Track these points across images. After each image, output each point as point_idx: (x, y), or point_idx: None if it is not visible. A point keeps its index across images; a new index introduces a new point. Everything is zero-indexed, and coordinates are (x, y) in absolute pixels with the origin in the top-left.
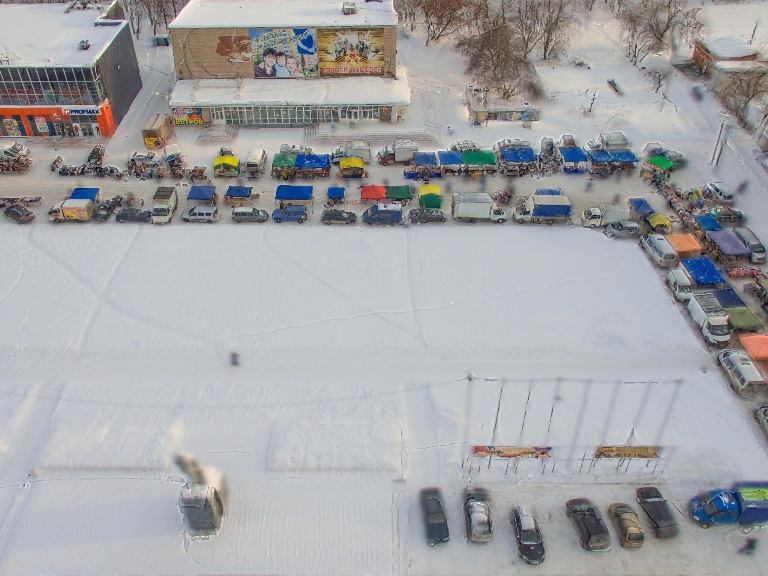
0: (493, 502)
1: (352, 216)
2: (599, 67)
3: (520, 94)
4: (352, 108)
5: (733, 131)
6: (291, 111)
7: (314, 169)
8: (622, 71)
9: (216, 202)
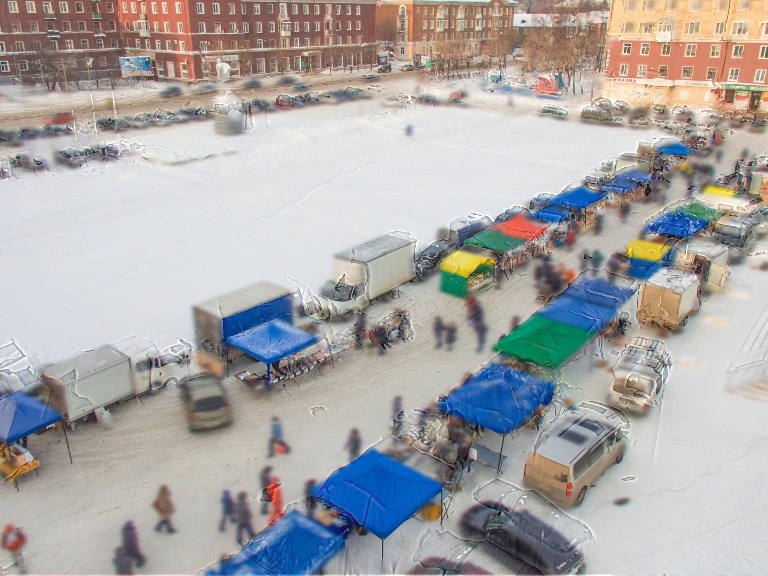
0: None
1: None
2: None
3: None
4: None
5: None
6: None
7: None
8: None
9: None
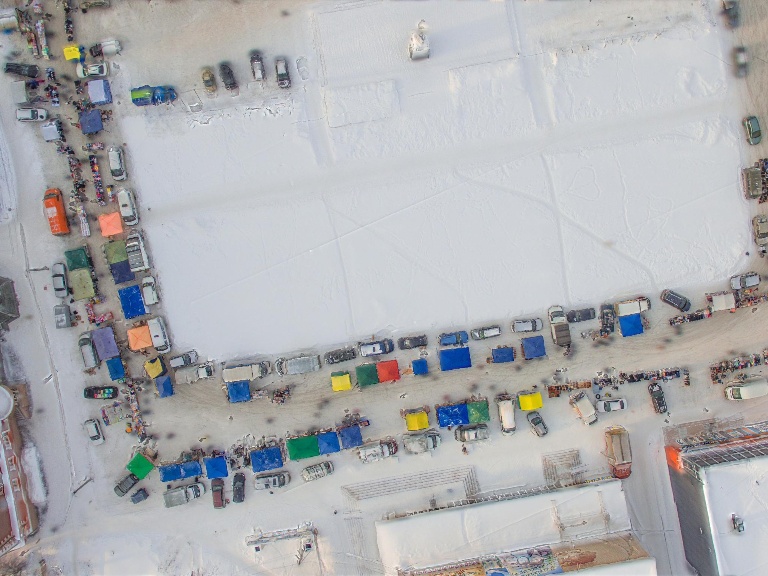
0: None
1: (402, 344)
2: None
3: None
4: None
5: (57, 548)
6: None
7: None
8: None
9: None
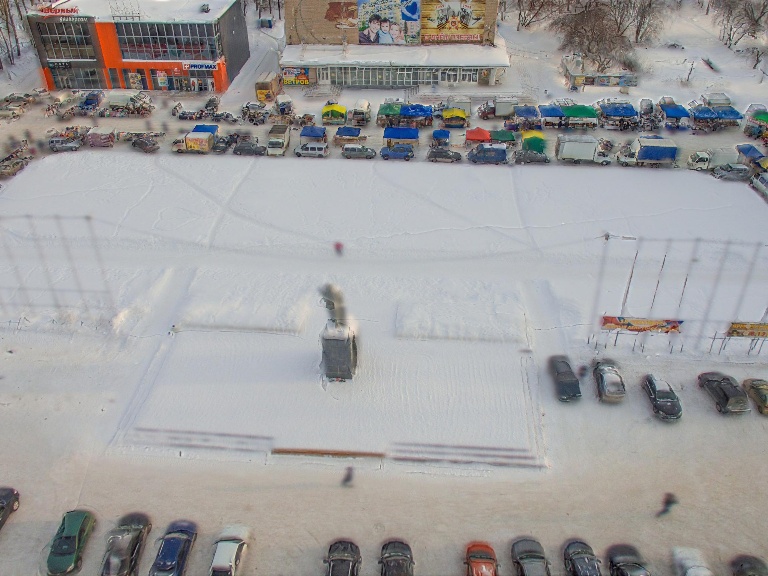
0: (622, 371)
1: (457, 155)
2: (693, 48)
3: (615, 66)
4: (452, 70)
5: None
6: (393, 73)
7: (418, 118)
8: (716, 52)
9: (325, 142)
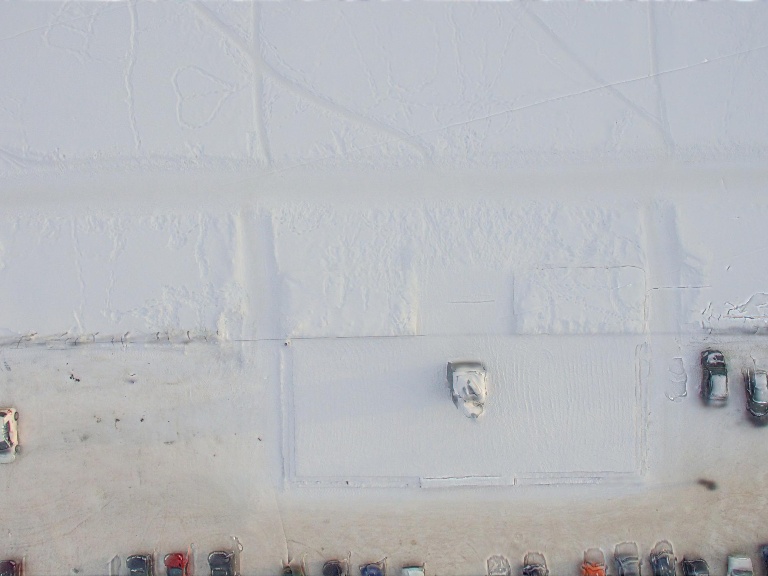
0: (728, 352)
1: None
2: None
3: None
4: None
5: None
6: None
7: None
8: None
9: None
